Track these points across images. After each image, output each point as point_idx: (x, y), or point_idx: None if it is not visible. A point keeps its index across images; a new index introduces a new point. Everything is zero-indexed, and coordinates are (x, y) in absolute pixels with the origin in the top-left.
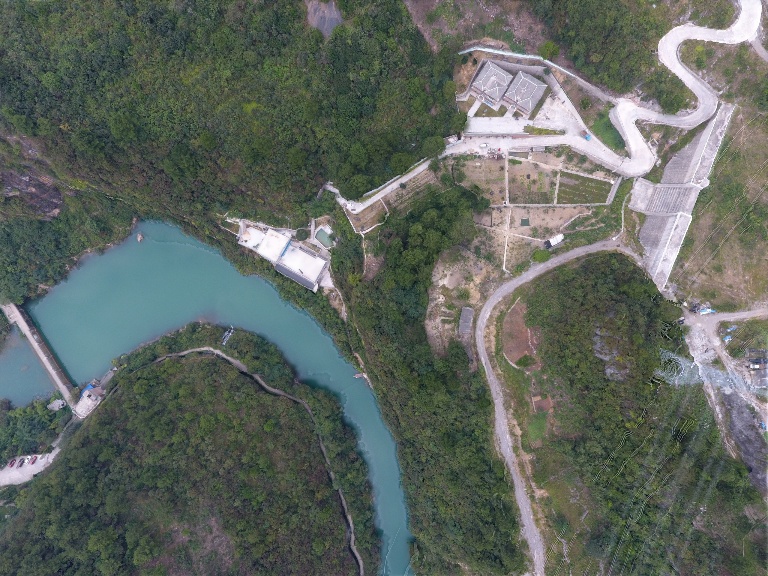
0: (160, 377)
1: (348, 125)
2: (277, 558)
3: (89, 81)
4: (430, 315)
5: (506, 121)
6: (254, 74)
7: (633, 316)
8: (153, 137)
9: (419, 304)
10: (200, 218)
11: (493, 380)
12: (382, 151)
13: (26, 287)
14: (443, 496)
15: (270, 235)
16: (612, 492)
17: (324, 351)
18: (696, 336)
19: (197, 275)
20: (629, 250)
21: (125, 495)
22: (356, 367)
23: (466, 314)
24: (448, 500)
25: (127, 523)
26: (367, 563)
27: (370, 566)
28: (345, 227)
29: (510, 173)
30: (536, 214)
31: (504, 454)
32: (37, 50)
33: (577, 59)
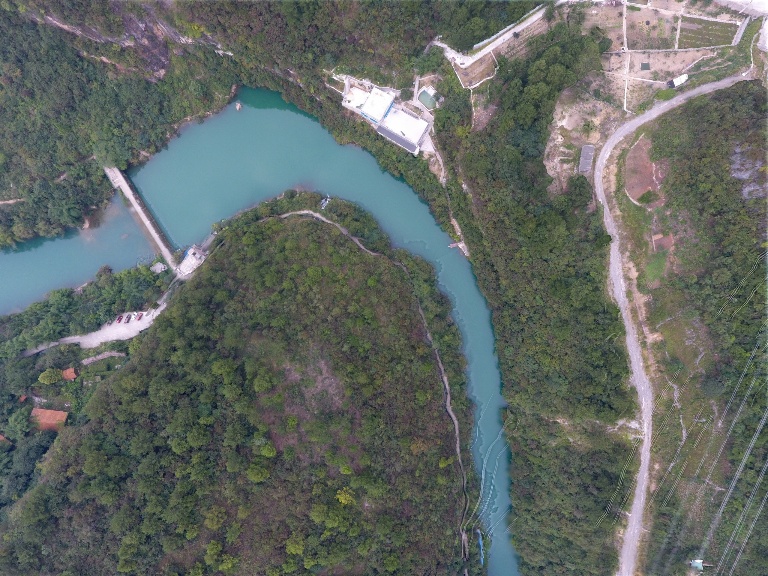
0: (265, 233)
1: None
2: (384, 401)
3: None
4: (548, 155)
5: None
6: None
7: None
8: None
9: (539, 142)
10: (308, 72)
11: (610, 222)
12: None
13: (130, 151)
14: (547, 349)
15: (375, 94)
16: (736, 325)
17: (421, 218)
18: None
19: (295, 142)
20: None
21: (242, 331)
22: (452, 235)
23: (587, 151)
24: (553, 352)
25: (244, 357)
26: (463, 423)
27: (466, 425)
28: (452, 83)
29: (628, 20)
30: (656, 58)
31: (617, 299)
32: None
33: None
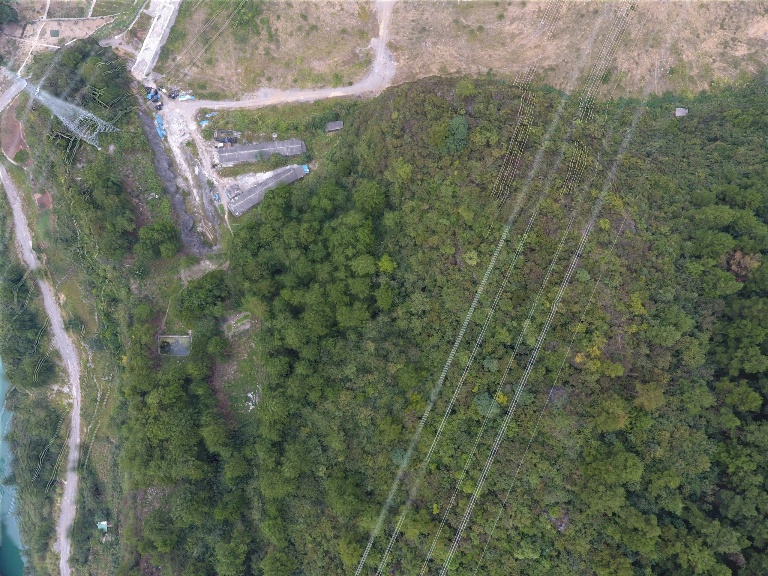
0: None
1: None
2: None
3: None
4: None
5: None
6: None
7: None
8: None
9: None
10: None
11: (9, 184)
12: None
13: None
14: None
15: None
16: (93, 278)
17: None
18: (174, 121)
19: None
20: (130, 48)
21: None
22: None
23: None
24: None
25: None
26: None
27: None
28: None
29: None
30: (68, 26)
31: (28, 261)
32: None
33: None
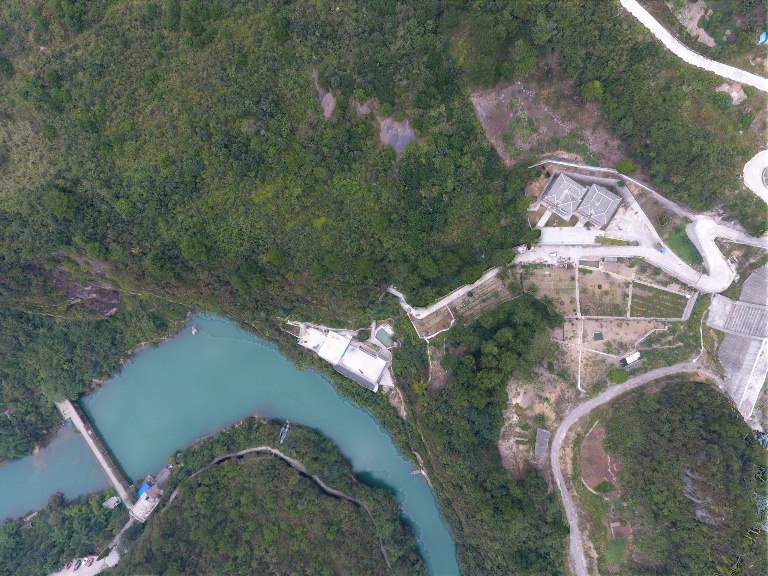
0: (220, 482)
1: (417, 238)
2: None
3: (161, 205)
4: (504, 435)
5: (577, 231)
6: (323, 189)
7: (727, 460)
8: (222, 254)
9: (494, 426)
10: (262, 323)
11: (568, 501)
12: (454, 267)
13: (81, 384)
14: None
15: (331, 337)
16: None
17: (382, 449)
18: None
19: (253, 370)
20: (710, 372)
21: None
22: (415, 465)
23: (542, 437)
24: None
25: None
26: None
27: None
28: (409, 331)
29: (580, 282)
30: (609, 327)
31: (578, 575)
32: (110, 177)
33: (655, 177)
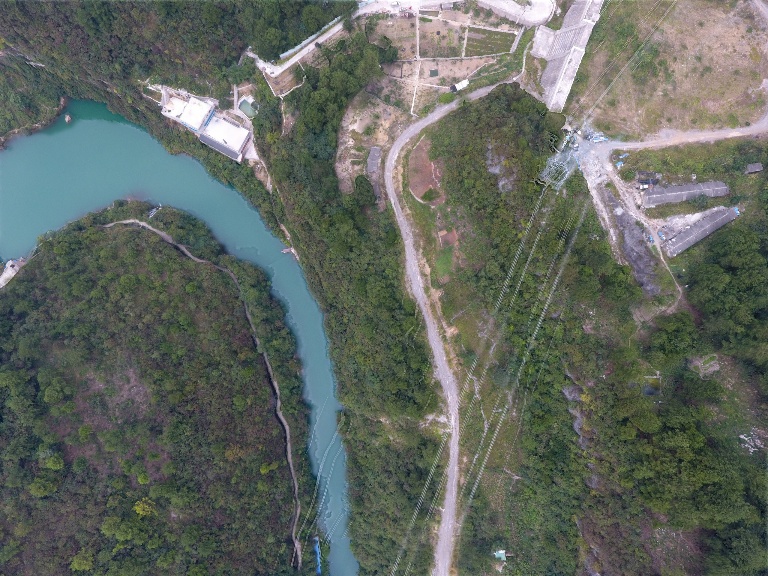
0: (82, 242)
1: None
2: (196, 408)
3: None
4: (340, 157)
5: None
6: None
7: (521, 127)
8: None
9: (328, 144)
10: (121, 82)
11: (403, 221)
12: (292, 1)
13: None
14: (362, 348)
15: (192, 103)
16: (513, 315)
17: (251, 225)
18: (590, 163)
19: (124, 153)
20: (529, 89)
21: (39, 341)
22: (283, 240)
23: (373, 153)
24: (366, 351)
25: (41, 368)
26: (293, 427)
27: (296, 430)
28: (265, 91)
29: (421, 31)
30: (445, 66)
31: (416, 295)
32: None
33: None
